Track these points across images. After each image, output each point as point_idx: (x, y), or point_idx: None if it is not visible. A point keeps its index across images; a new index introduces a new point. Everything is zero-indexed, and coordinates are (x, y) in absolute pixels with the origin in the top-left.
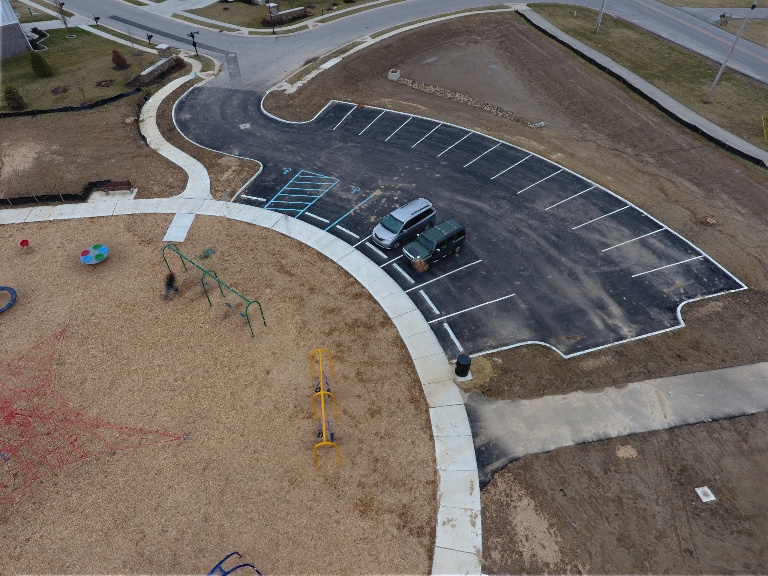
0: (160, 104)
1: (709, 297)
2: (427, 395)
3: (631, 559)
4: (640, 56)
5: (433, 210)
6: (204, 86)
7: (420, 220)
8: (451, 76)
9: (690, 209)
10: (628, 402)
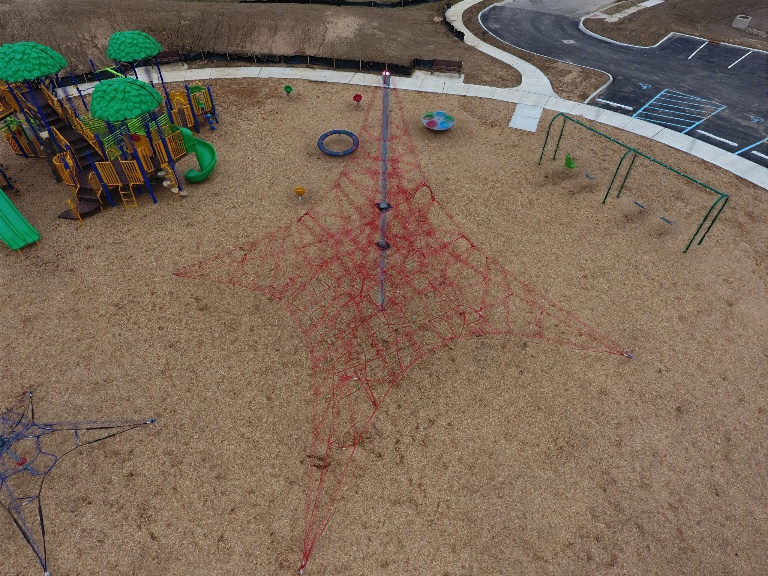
0: (463, 13)
1: None
2: None
3: None
4: None
5: None
6: (505, 6)
7: None
8: None
9: None
10: None
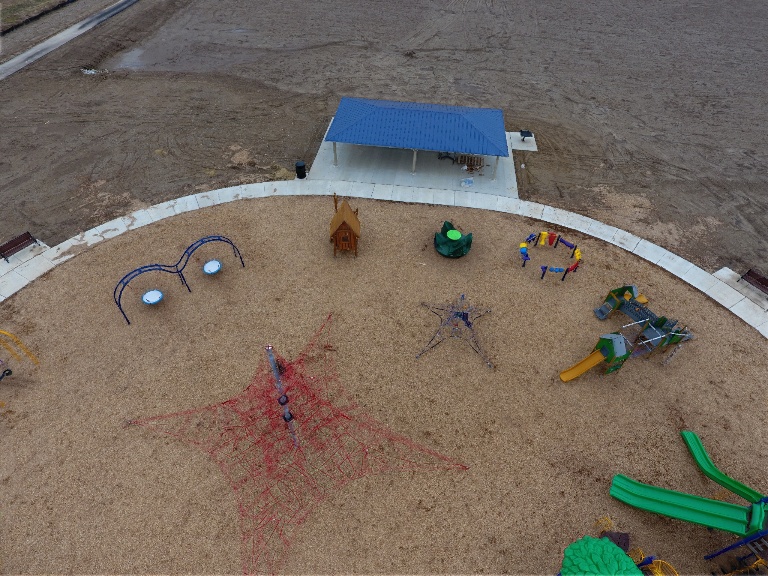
0: None
1: None
2: None
3: None
4: None
5: None
6: None
7: None
8: None
9: None
10: None
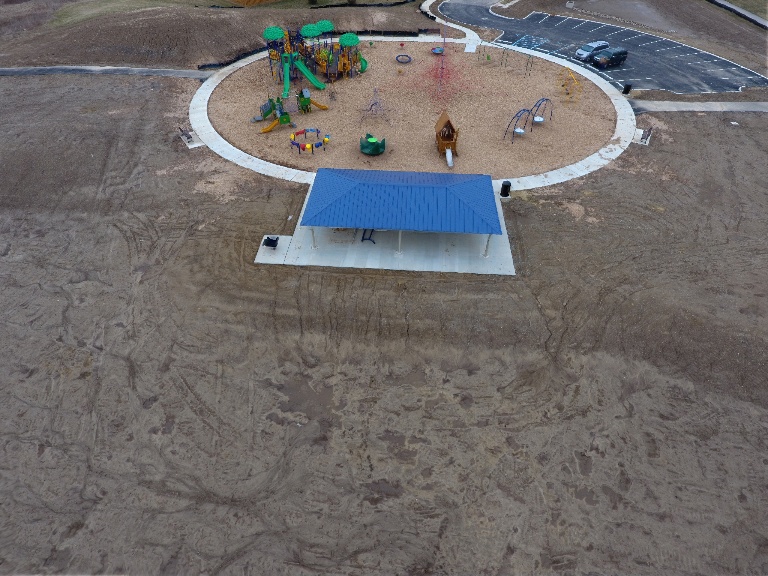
0: (429, 7)
1: (759, 86)
2: (610, 97)
3: (698, 130)
4: (751, 1)
5: (609, 46)
6: (449, 2)
7: (602, 49)
8: (609, 8)
9: (761, 63)
10: (705, 105)
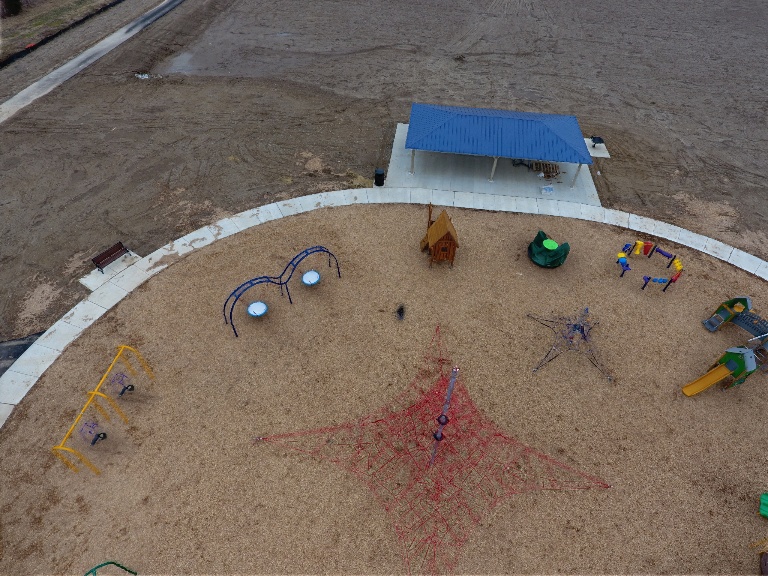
0: None
1: None
2: (5, 419)
3: (1, 273)
4: None
5: None
6: None
7: None
8: None
9: None
10: None
